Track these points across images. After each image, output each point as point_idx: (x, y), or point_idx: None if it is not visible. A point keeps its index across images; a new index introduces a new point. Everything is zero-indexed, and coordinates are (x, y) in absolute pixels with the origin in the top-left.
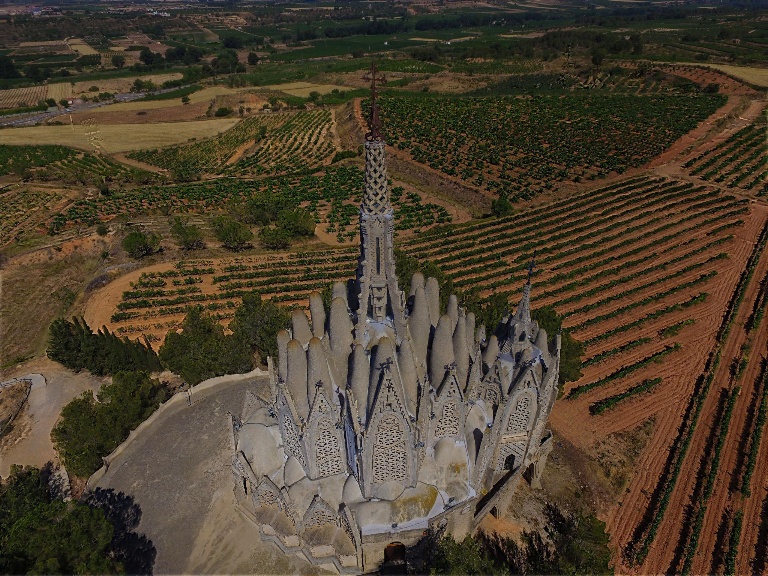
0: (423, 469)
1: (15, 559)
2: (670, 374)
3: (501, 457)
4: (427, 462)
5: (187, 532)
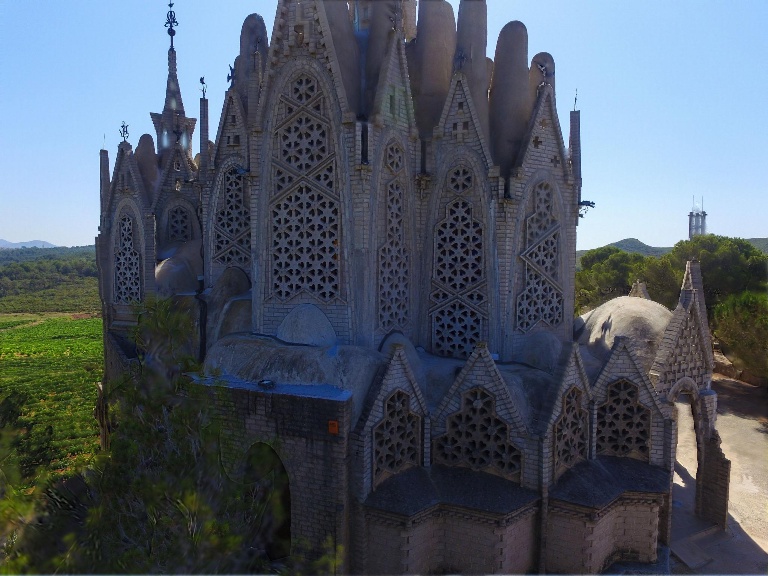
0: None
1: None
2: None
3: None
4: None
5: (767, 463)
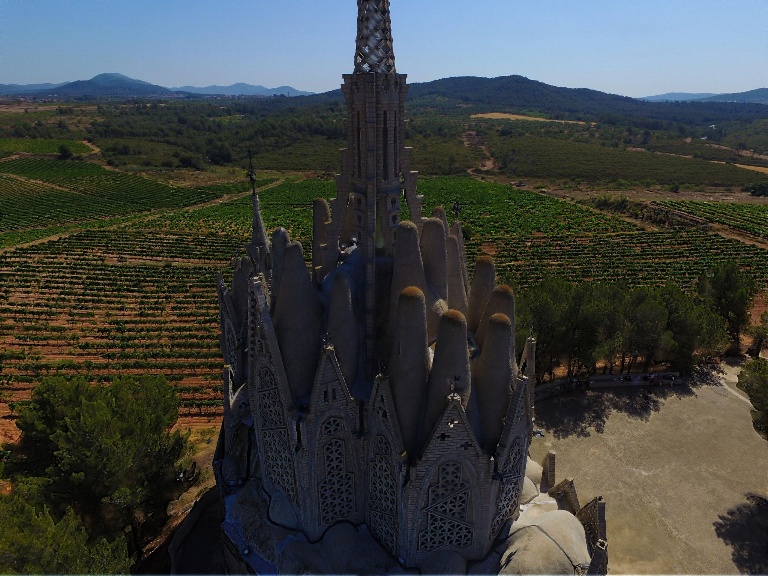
0: None
1: None
2: (2, 437)
3: None
4: None
5: None
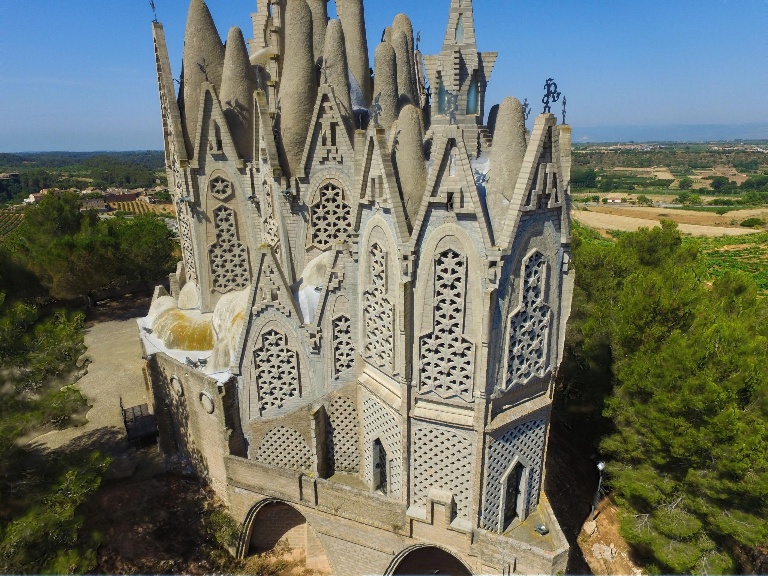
0: (223, 295)
1: (110, 222)
2: None
3: (368, 434)
4: (236, 293)
5: None
